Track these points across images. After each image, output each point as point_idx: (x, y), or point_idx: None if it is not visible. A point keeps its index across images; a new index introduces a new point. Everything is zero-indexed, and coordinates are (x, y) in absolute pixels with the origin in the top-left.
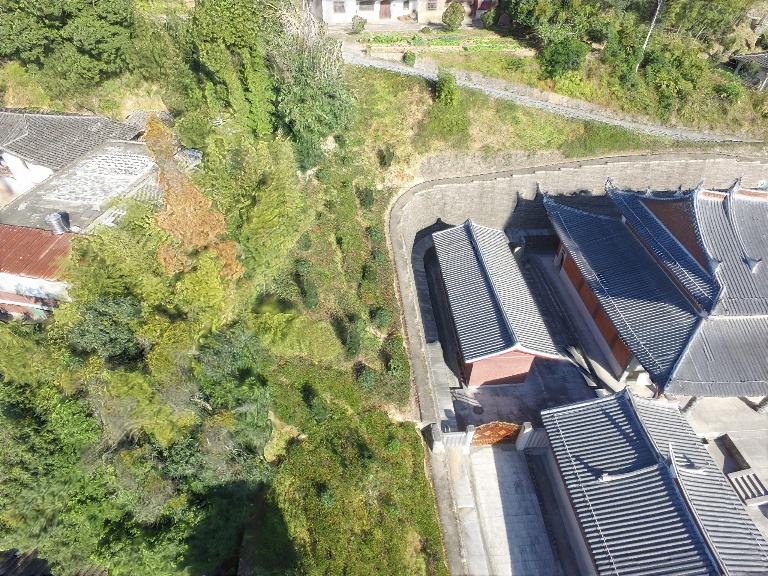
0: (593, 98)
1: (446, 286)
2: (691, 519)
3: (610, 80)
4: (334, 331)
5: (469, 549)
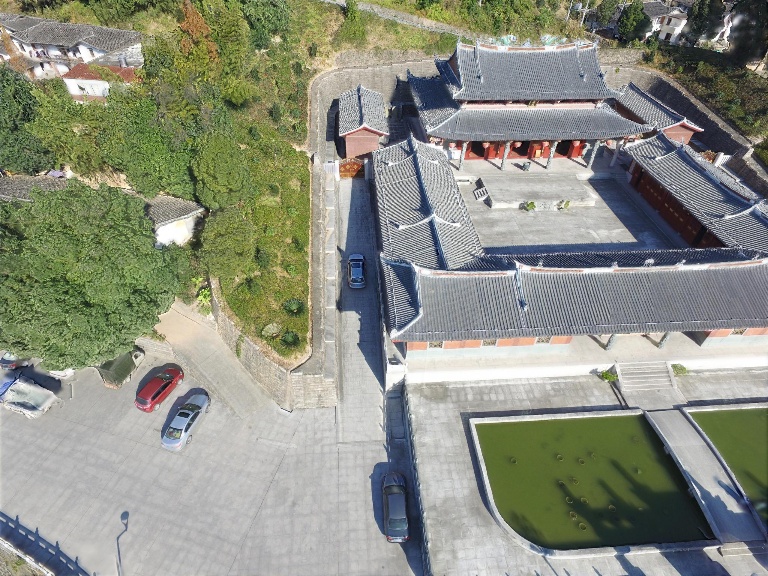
0: (451, 22)
1: (339, 112)
2: (418, 166)
3: (461, 10)
4: (269, 115)
5: (327, 200)
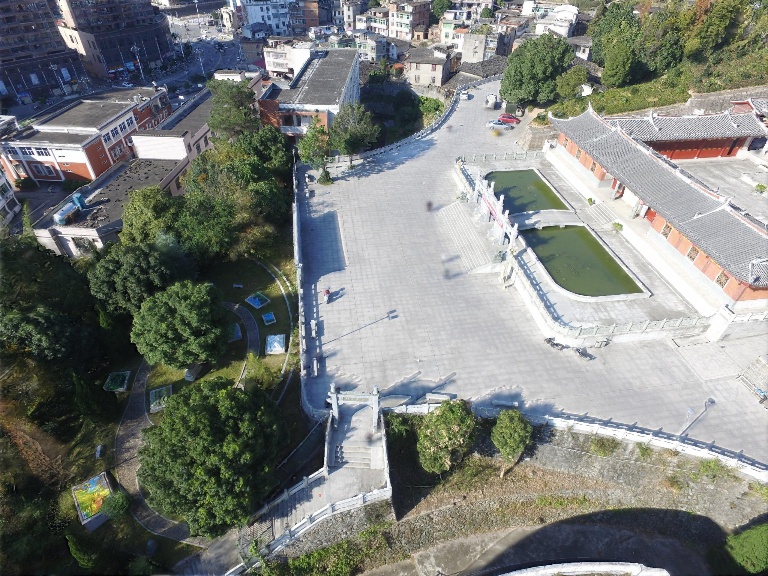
0: None
1: None
2: None
3: None
4: None
5: None
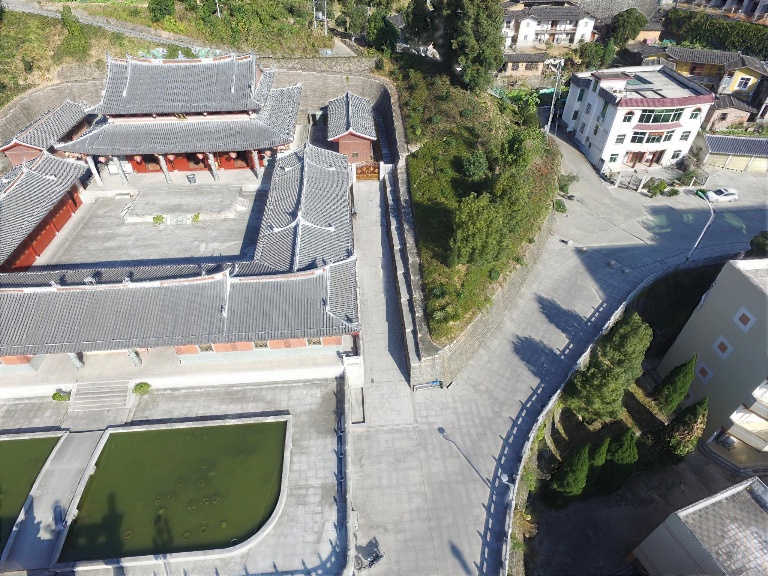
0: (188, 34)
1: None
2: None
3: (196, 22)
4: None
5: None
